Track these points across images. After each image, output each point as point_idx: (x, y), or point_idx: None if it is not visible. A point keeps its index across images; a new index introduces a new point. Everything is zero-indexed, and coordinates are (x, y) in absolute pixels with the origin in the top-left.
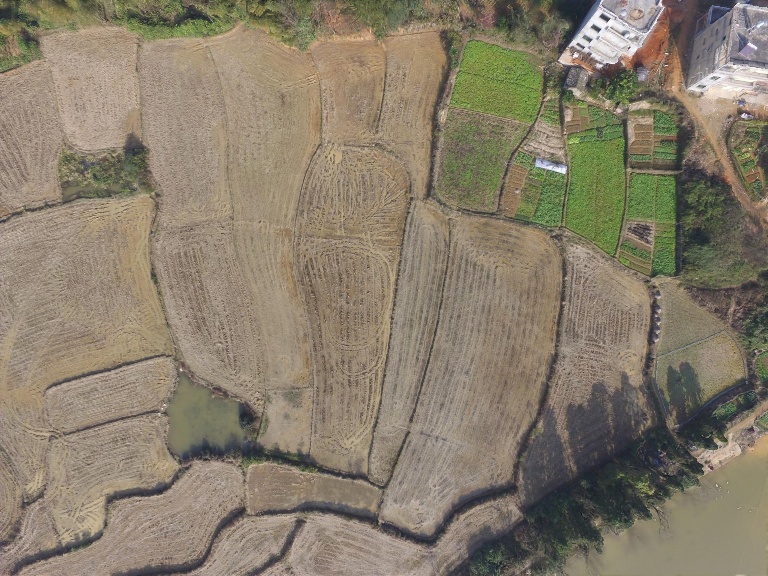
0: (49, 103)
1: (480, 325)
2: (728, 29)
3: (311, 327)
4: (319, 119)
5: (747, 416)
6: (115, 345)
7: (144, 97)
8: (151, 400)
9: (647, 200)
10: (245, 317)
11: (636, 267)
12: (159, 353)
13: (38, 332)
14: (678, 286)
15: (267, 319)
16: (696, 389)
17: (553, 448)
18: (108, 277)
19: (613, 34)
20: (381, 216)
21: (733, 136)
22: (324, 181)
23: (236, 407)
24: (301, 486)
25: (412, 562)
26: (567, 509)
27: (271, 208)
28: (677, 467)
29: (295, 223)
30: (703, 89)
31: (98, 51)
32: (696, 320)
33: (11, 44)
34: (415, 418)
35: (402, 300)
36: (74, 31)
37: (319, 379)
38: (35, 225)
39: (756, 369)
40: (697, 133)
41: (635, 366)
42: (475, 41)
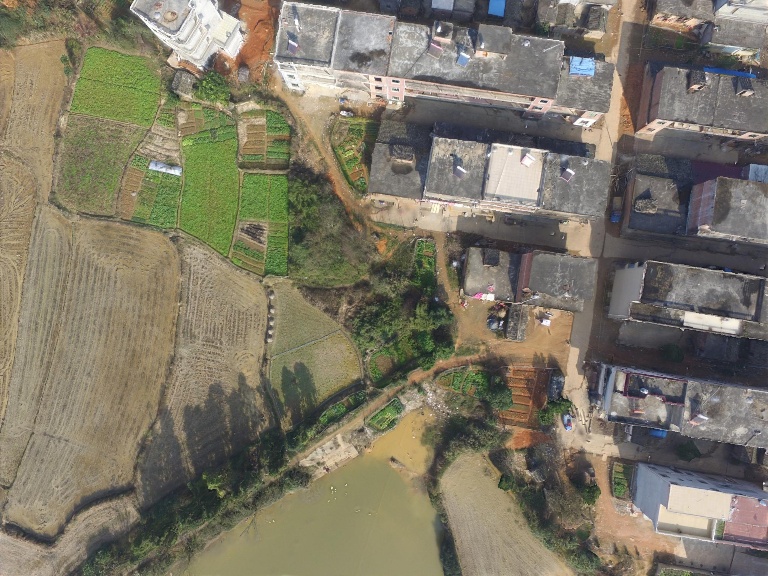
0: None
1: (102, 327)
2: None
3: None
4: None
5: (354, 417)
6: None
7: None
8: None
9: (259, 200)
10: None
11: (249, 267)
12: None
13: None
14: (292, 286)
15: None
16: (311, 390)
17: (171, 449)
18: None
19: None
20: (10, 221)
21: (336, 134)
22: None
23: None
24: None
25: (33, 562)
26: None
27: None
28: (285, 469)
29: None
30: (301, 88)
31: None
32: (311, 320)
33: None
34: (38, 419)
35: (28, 303)
36: None
37: None
38: None
39: (370, 369)
40: (301, 132)
41: (252, 367)
42: (94, 48)
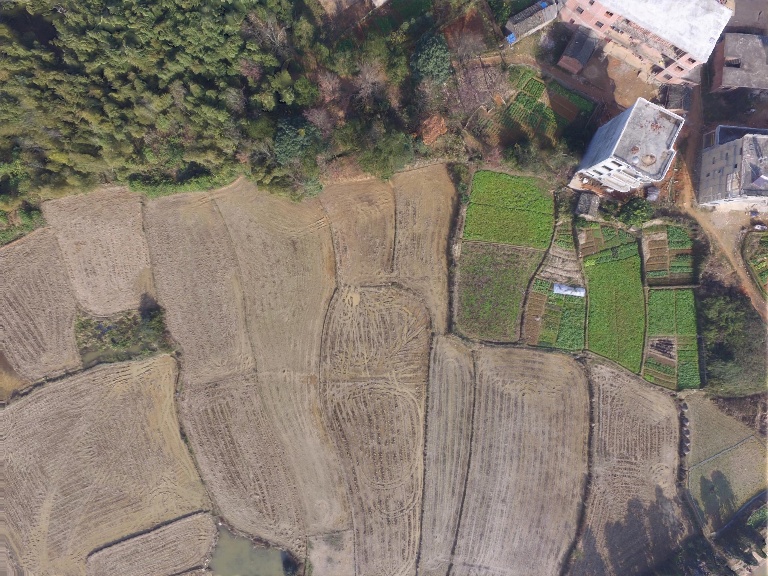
0: (58, 270)
1: (512, 453)
2: (739, 159)
3: (345, 471)
4: (333, 263)
5: None
6: (152, 506)
7: (154, 257)
8: (193, 556)
9: (667, 315)
10: (278, 467)
11: (661, 383)
12: (196, 509)
13: (73, 501)
14: (704, 397)
15: (301, 467)
16: (729, 495)
17: (594, 566)
18: (137, 440)
19: (625, 176)
20: (404, 354)
21: (748, 247)
22: (344, 325)
23: (278, 555)
24: None
25: None
26: None
27: (294, 356)
28: None
29: (319, 370)
30: (715, 204)
31: (102, 213)
32: (724, 428)
33: (14, 218)
34: (456, 550)
35: (433, 436)
36: (76, 199)
37: (358, 521)
38: (58, 395)
39: None
40: (712, 247)
41: (668, 478)
42: (482, 171)
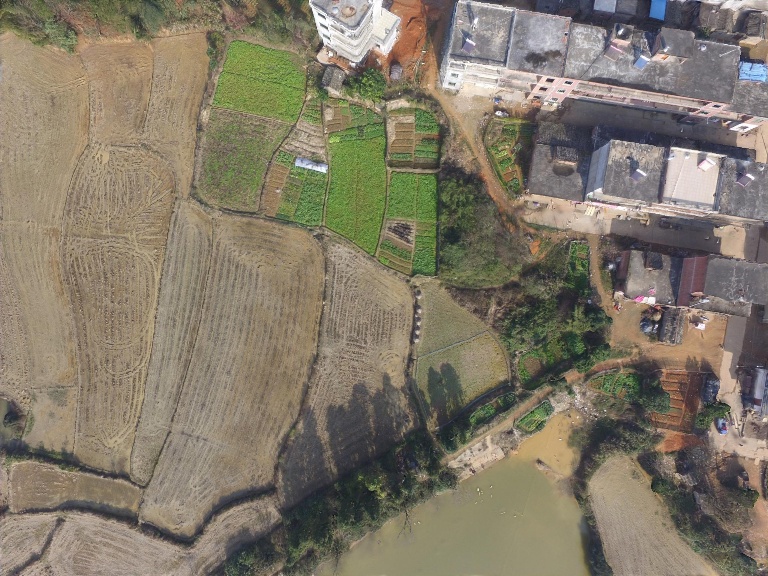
0: None
1: (242, 325)
2: (453, 26)
3: (76, 326)
4: (87, 120)
5: (505, 419)
6: None
7: None
8: None
9: (407, 199)
10: (13, 316)
11: (396, 266)
12: None
13: None
14: (439, 286)
15: (34, 318)
16: (458, 391)
17: (313, 449)
18: None
19: (335, 32)
20: (147, 216)
21: (490, 134)
22: (91, 181)
23: (4, 405)
24: (63, 485)
25: (170, 563)
26: (321, 511)
27: (39, 208)
28: None
29: (61, 223)
30: (456, 87)
31: None
32: (458, 320)
33: None
34: (176, 418)
35: (165, 299)
36: None
37: (83, 378)
38: None
39: (518, 371)
40: (453, 131)
41: (397, 367)
42: (238, 41)
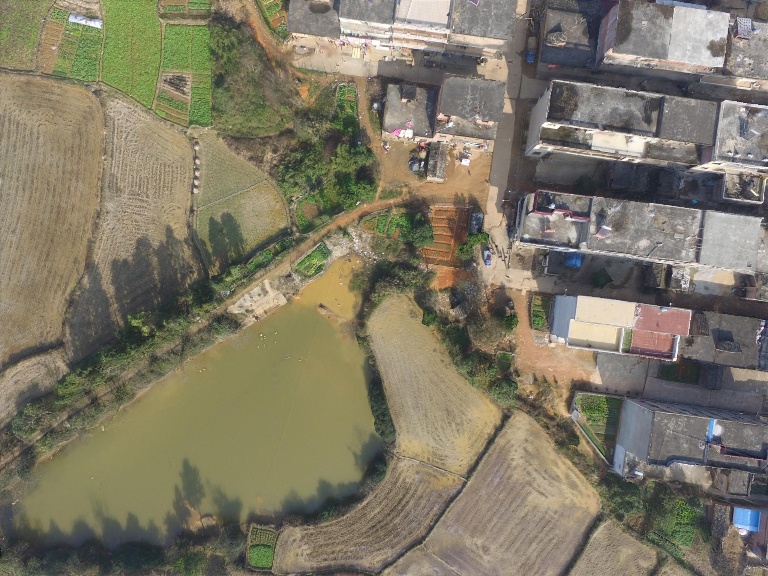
0: None
1: (25, 184)
2: None
3: None
4: None
5: (281, 262)
6: None
7: None
8: None
9: (182, 51)
10: None
11: (173, 119)
12: None
13: None
14: (217, 137)
15: None
16: (239, 239)
17: (99, 303)
18: None
19: None
20: None
21: None
22: None
23: None
24: None
25: None
26: None
27: None
28: (213, 315)
29: None
30: None
31: None
32: (237, 170)
33: None
34: None
35: None
36: None
37: None
38: None
39: (296, 217)
40: None
41: (179, 219)
42: None
